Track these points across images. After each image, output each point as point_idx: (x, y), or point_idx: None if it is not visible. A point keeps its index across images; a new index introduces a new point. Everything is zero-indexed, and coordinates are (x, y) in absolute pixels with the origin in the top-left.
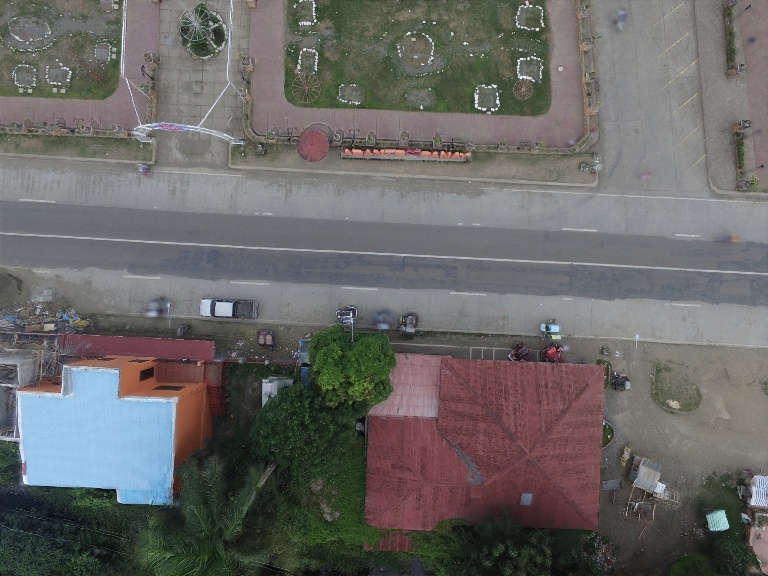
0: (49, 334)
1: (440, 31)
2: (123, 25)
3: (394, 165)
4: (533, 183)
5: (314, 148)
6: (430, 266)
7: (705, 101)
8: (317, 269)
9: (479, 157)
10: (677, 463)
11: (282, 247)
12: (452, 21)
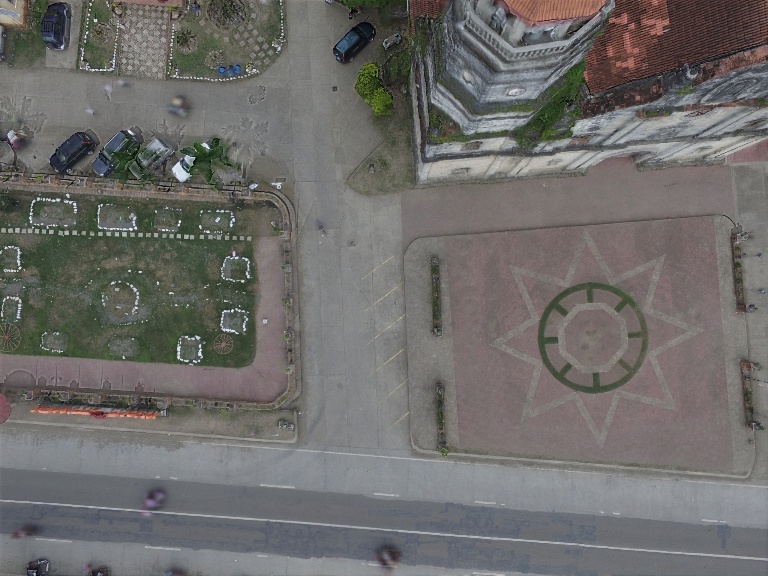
0: None
1: (146, 280)
2: None
3: (92, 417)
4: (231, 438)
5: None
6: (125, 519)
7: (410, 358)
8: (12, 519)
9: (178, 411)
10: None
11: None
12: (158, 270)
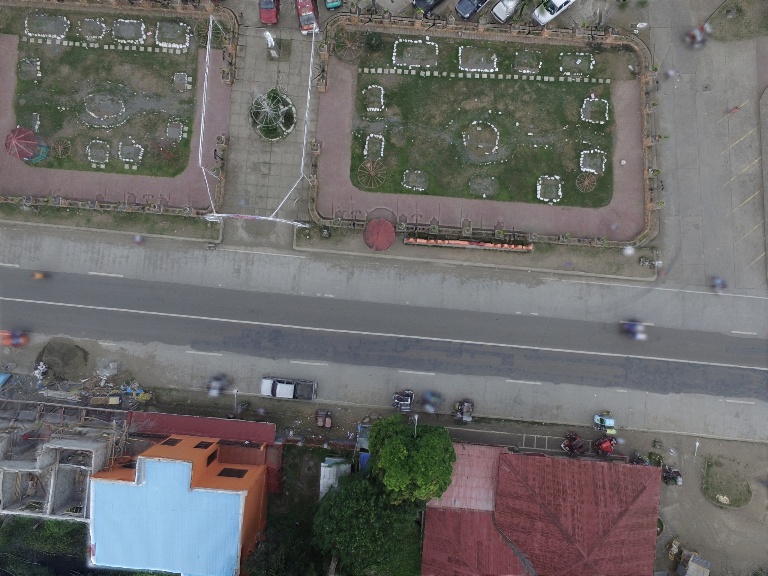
0: (116, 410)
1: (505, 121)
2: (202, 116)
3: (455, 252)
4: (592, 275)
5: (381, 238)
6: (487, 353)
7: (766, 200)
8: (376, 352)
9: (540, 247)
10: (724, 558)
11: (342, 329)
12: (517, 111)
